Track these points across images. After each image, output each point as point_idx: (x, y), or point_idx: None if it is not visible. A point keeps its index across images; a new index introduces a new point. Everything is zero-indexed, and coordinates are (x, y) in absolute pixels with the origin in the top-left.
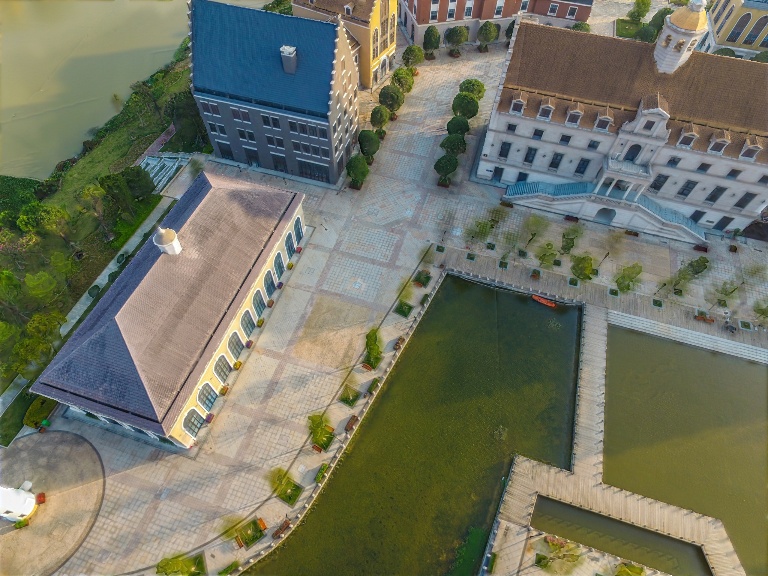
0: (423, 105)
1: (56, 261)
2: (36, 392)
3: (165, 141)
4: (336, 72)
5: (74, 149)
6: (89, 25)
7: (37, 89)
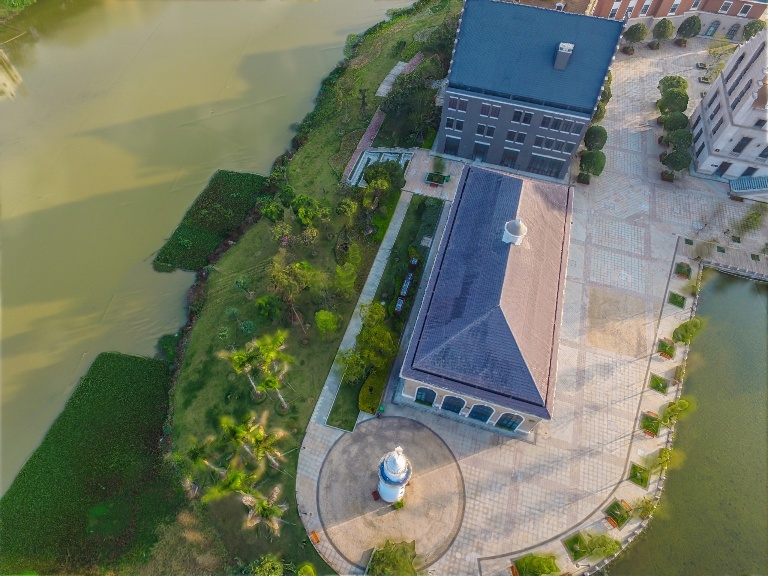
0: (617, 101)
1: (356, 252)
2: (408, 378)
3: (373, 137)
4: None
5: (283, 145)
6: (251, 23)
7: (223, 86)
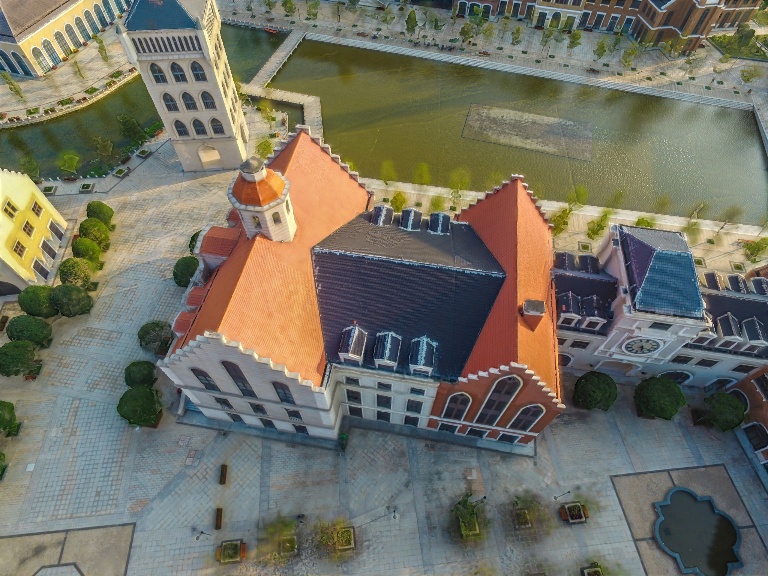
0: None
1: None
2: None
3: None
4: None
5: None
6: None
7: None
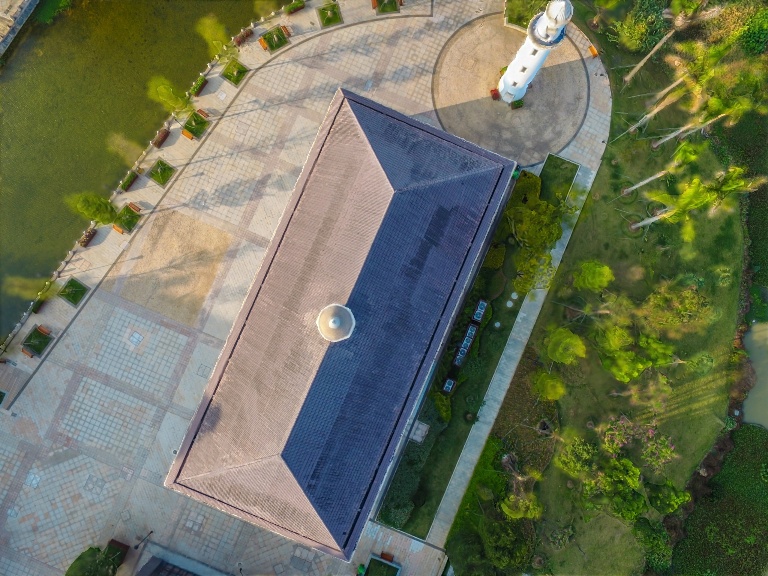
0: None
1: (553, 383)
2: (507, 159)
3: None
4: None
5: None
6: None
7: None
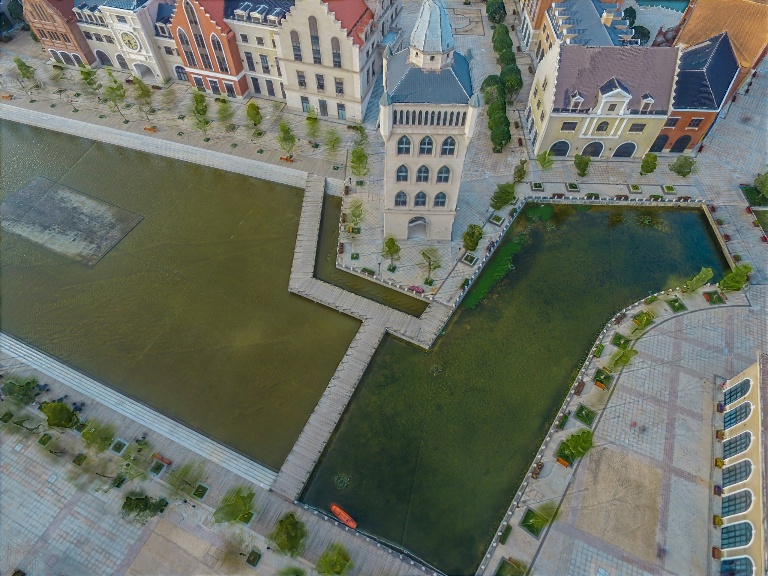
0: None
1: None
2: None
3: None
4: None
5: None
6: None
7: None
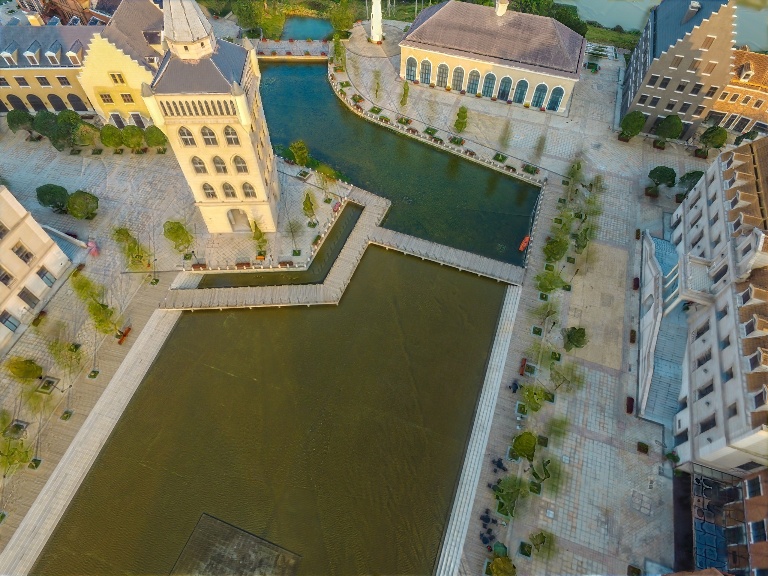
0: None
1: None
2: None
3: None
4: (692, 37)
5: (613, 26)
6: (764, 9)
7: None
